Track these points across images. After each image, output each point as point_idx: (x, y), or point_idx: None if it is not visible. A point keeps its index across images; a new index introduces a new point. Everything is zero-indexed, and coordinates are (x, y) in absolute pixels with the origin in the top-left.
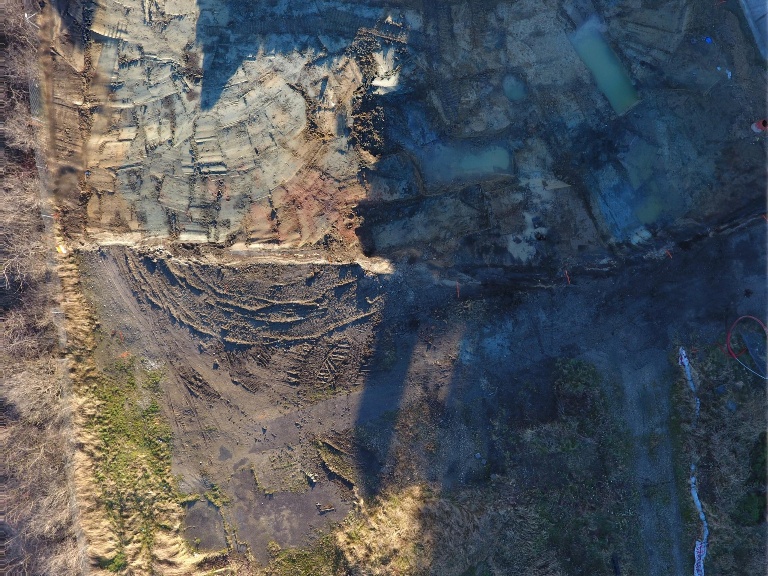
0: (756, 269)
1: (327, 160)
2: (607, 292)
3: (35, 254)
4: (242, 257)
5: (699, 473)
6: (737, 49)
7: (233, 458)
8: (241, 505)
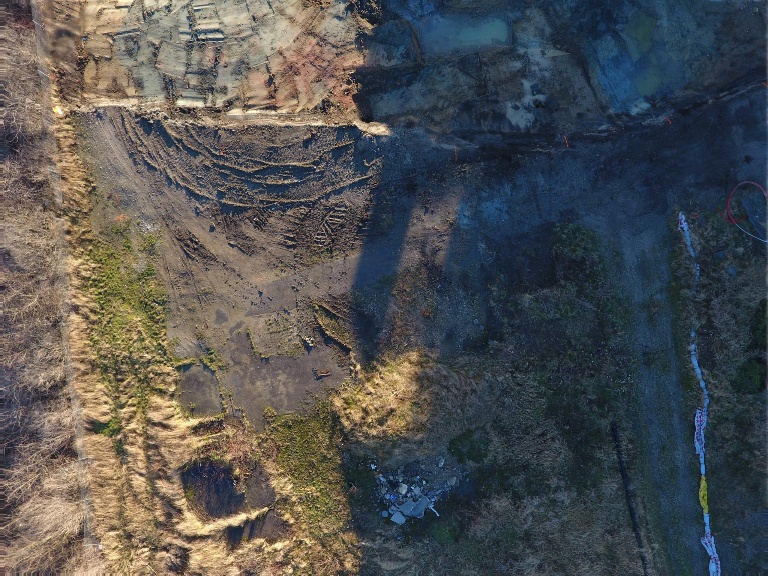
0: (756, 135)
1: (325, 26)
2: (606, 156)
3: (31, 108)
4: (239, 120)
5: (699, 340)
6: None
7: (229, 322)
8: (237, 369)
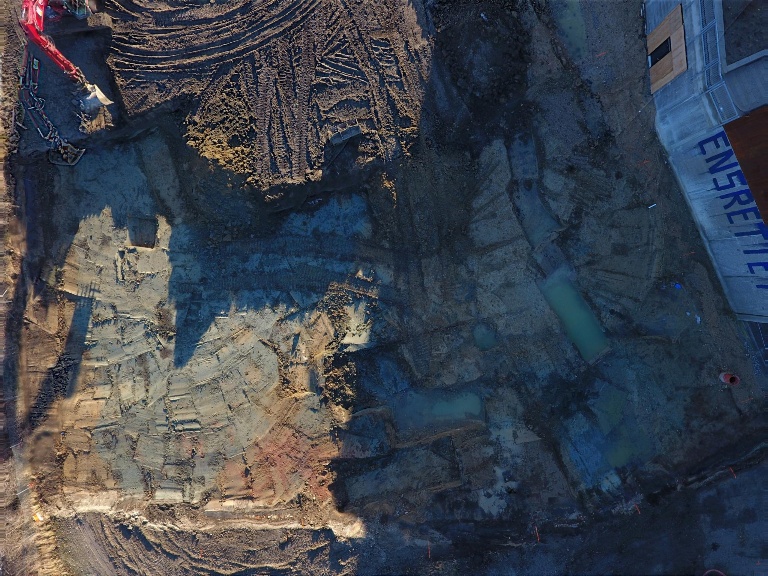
0: (723, 523)
1: (300, 418)
2: (576, 550)
3: (11, 534)
4: (216, 520)
5: None
6: (706, 297)
7: None
8: None
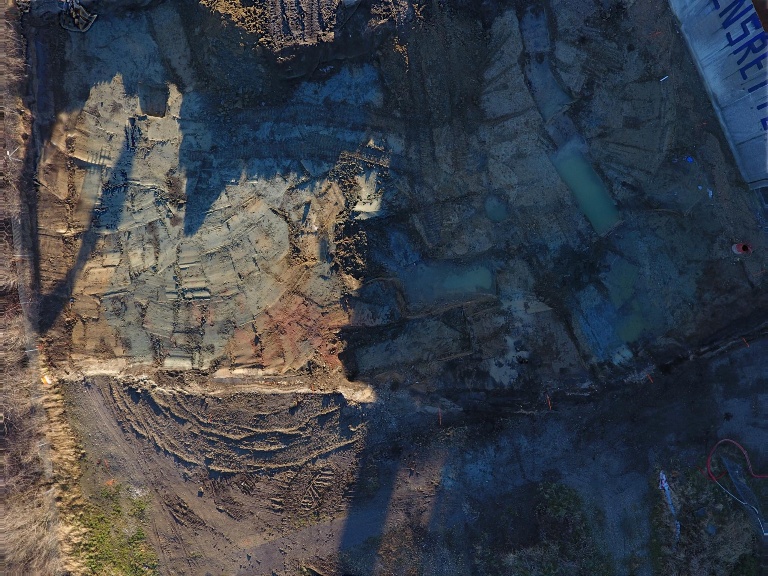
0: (736, 392)
1: (310, 286)
2: (588, 418)
3: (20, 391)
4: (226, 385)
5: None
6: (718, 169)
7: None
8: None
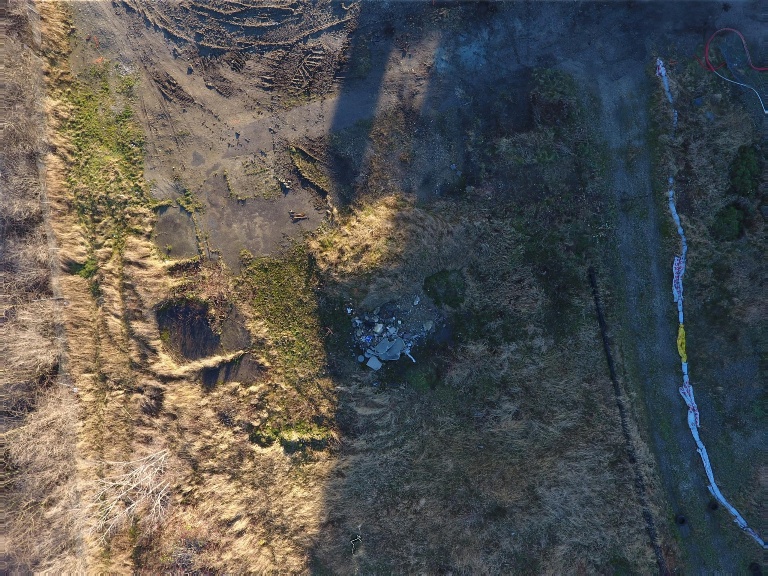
0: None
1: None
2: (584, 1)
3: None
4: None
5: (677, 187)
6: None
7: (206, 163)
8: (213, 212)
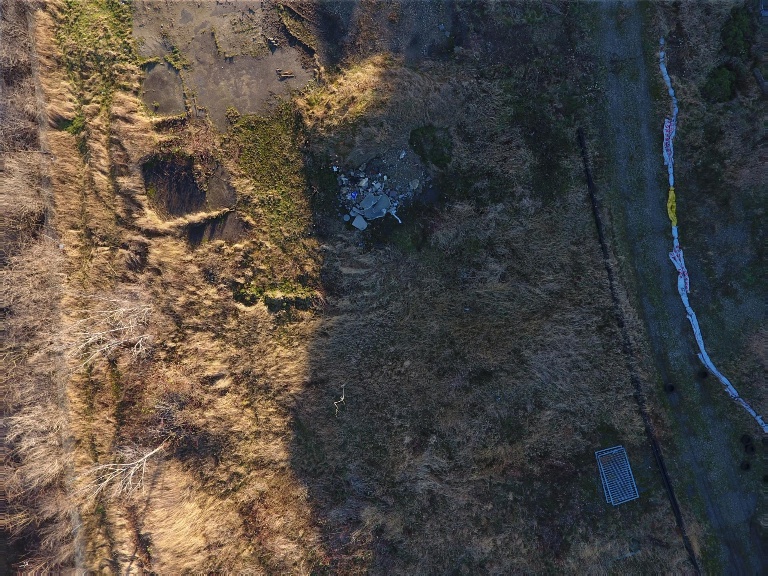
0: None
1: None
2: None
3: None
4: None
5: (668, 49)
6: None
7: (194, 21)
8: (201, 69)
